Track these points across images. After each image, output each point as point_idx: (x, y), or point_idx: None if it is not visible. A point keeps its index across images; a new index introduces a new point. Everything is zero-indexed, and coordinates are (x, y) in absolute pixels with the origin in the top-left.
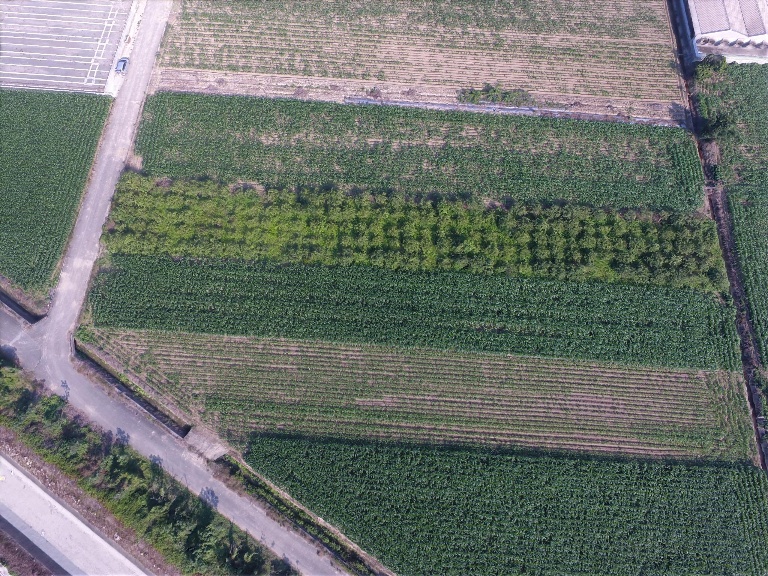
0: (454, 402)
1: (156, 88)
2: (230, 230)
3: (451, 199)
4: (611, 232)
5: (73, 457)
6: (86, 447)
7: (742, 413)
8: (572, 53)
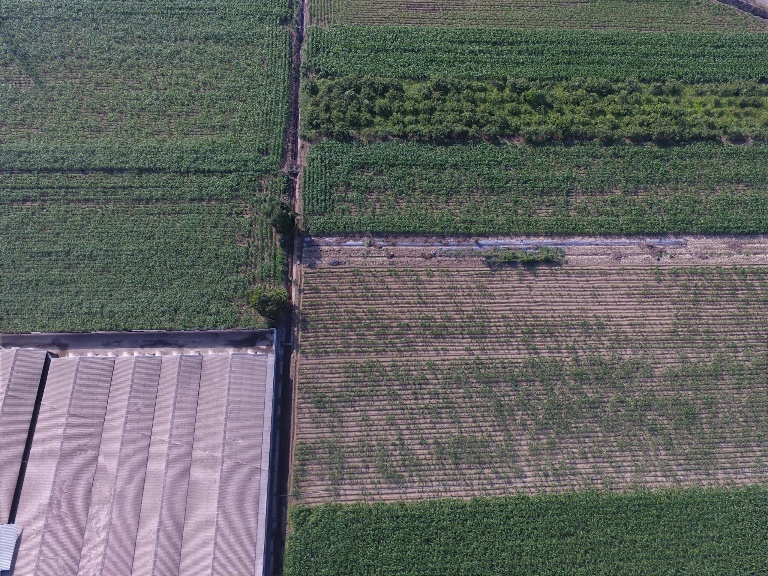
0: (522, 6)
1: None
2: (733, 104)
3: (552, 139)
4: (403, 117)
5: None
6: None
7: (315, 5)
8: None
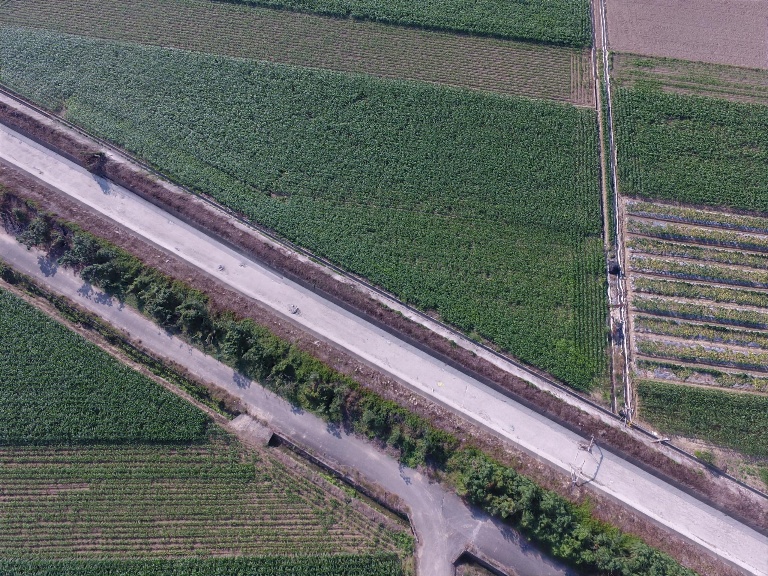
0: None
1: None
2: None
3: None
4: None
5: (370, 408)
6: (364, 418)
7: None
8: None
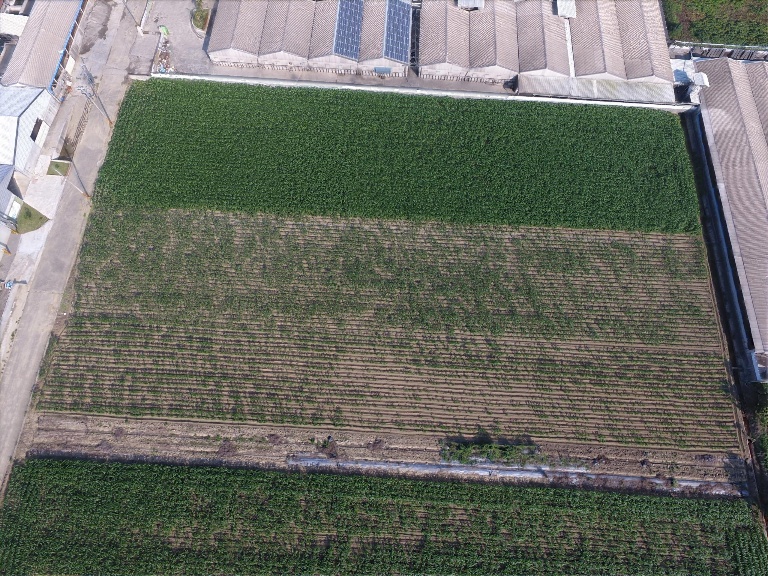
0: None
1: (28, 446)
2: None
3: None
4: None
5: None
6: None
7: None
8: (592, 370)
